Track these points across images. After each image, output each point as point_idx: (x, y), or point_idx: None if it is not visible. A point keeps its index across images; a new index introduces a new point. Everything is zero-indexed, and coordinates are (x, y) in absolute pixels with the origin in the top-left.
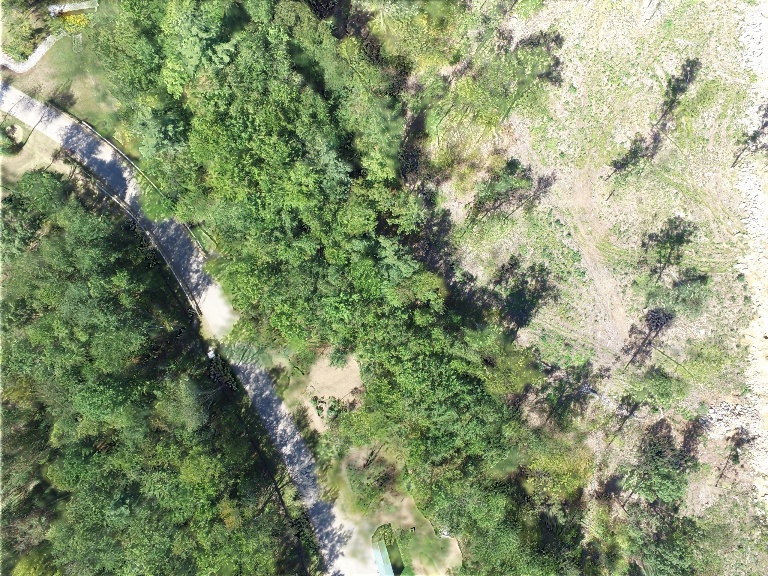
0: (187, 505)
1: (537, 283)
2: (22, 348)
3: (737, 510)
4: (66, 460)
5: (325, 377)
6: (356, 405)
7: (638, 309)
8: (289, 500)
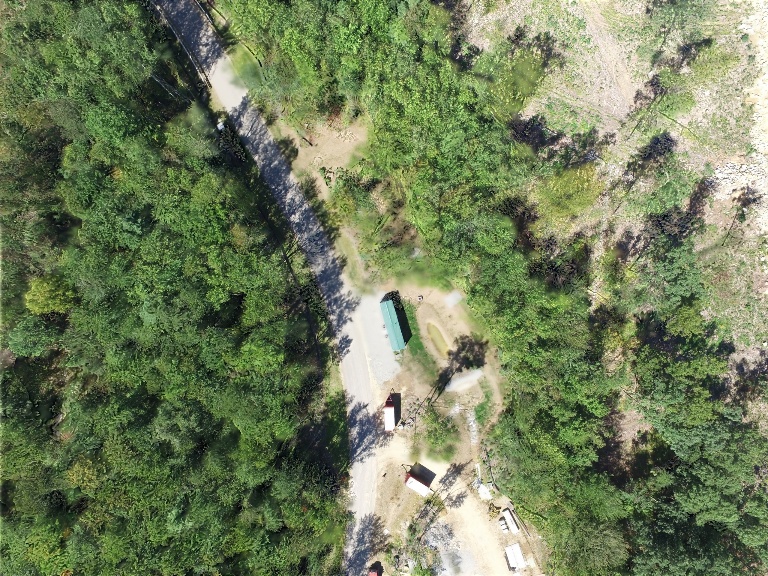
0: (198, 226)
1: (543, 52)
2: (36, 63)
3: (744, 269)
4: (79, 178)
5: (333, 149)
6: (364, 176)
7: (643, 74)
8: (297, 268)
